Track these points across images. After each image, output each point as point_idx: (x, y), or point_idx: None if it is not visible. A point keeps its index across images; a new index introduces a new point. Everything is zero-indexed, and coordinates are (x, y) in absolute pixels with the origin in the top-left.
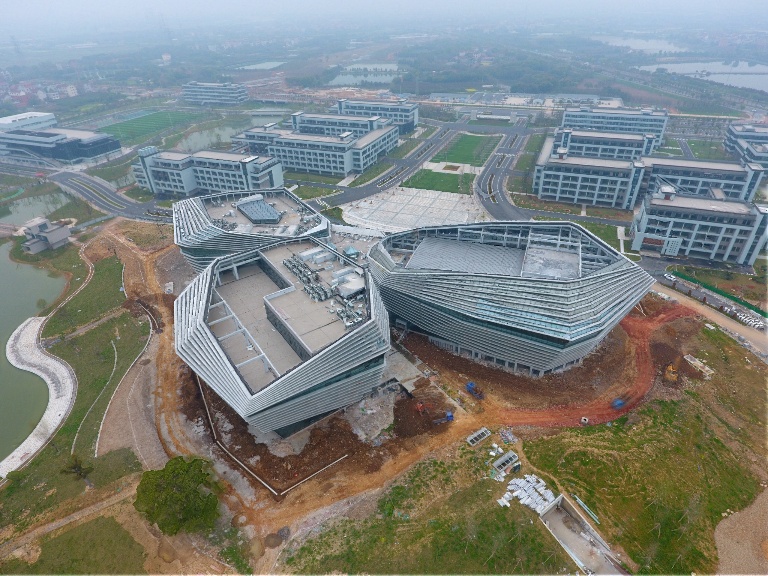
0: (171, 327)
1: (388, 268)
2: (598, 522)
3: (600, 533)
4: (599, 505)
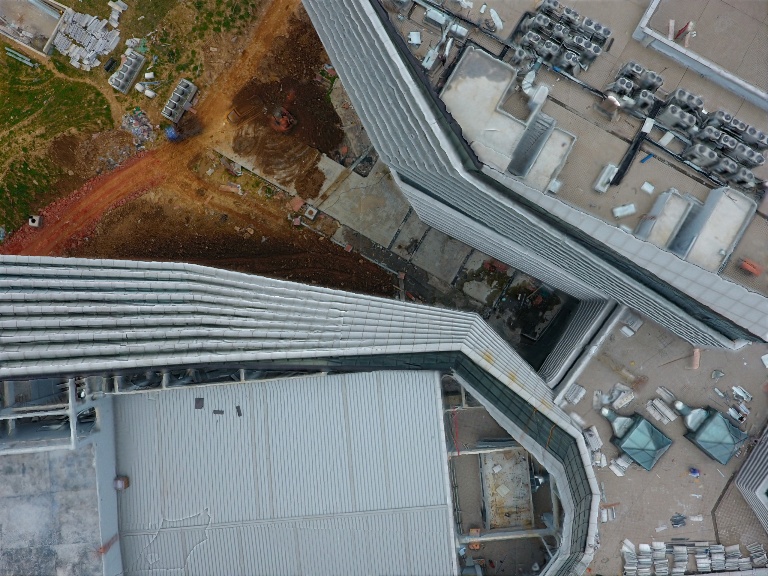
0: None
1: (478, 370)
2: (7, 48)
3: (7, 40)
4: (5, 71)
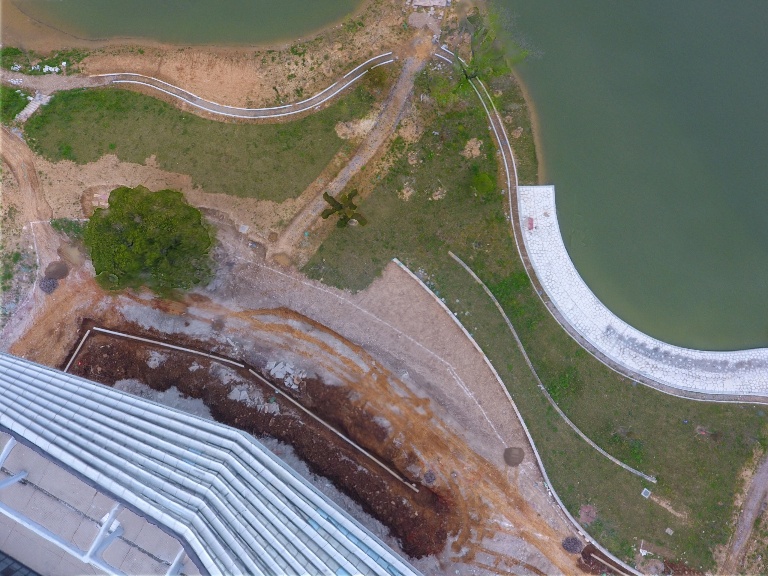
0: (560, 568)
1: None
2: None
3: None
4: None
